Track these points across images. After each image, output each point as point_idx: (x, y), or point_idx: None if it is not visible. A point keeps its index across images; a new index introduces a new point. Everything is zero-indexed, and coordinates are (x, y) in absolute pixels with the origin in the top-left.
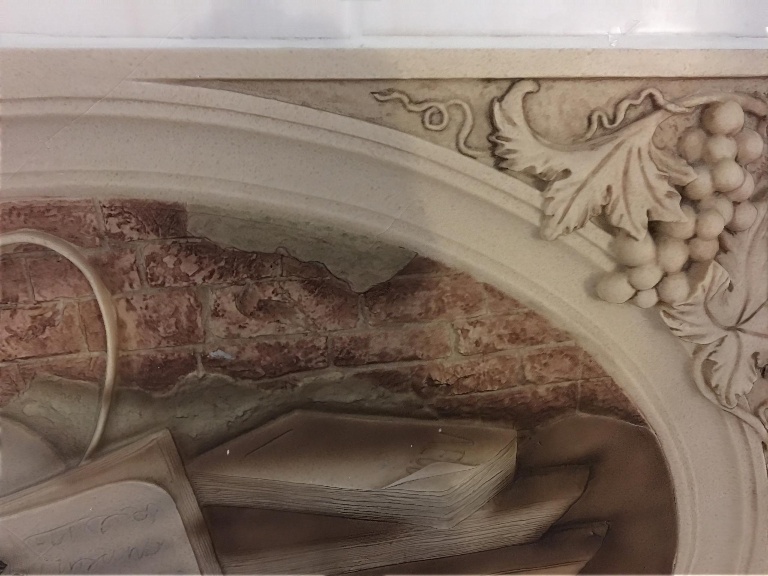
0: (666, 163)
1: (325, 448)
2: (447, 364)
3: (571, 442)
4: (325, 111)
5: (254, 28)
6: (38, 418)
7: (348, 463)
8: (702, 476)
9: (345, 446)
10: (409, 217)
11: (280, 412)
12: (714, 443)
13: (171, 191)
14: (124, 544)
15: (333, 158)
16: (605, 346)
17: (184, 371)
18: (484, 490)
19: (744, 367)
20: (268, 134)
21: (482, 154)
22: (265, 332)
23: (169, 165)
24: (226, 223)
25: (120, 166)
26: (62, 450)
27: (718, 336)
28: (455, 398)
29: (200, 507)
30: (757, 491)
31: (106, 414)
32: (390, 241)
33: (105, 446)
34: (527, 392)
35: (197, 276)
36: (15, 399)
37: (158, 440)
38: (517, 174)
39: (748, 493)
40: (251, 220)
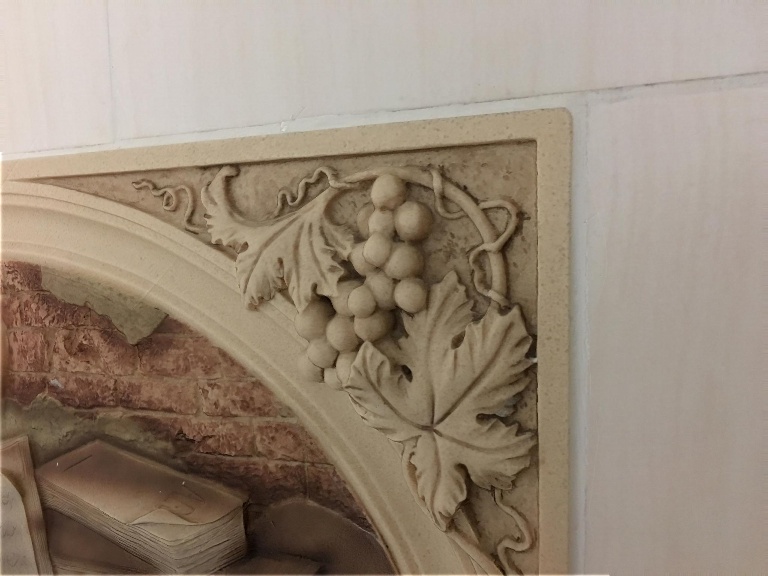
0: (336, 238)
1: (108, 477)
2: (194, 421)
3: (302, 531)
4: (101, 197)
5: (67, 141)
6: None
7: (117, 494)
8: None
9: (119, 479)
10: (163, 283)
11: (89, 439)
12: None
13: (34, 256)
14: None
15: (115, 234)
16: (322, 429)
17: (38, 392)
18: (212, 555)
19: (446, 479)
20: (74, 215)
21: (200, 230)
22: (79, 369)
23: (35, 238)
24: (59, 281)
25: (14, 239)
26: None
27: (409, 434)
28: (203, 456)
29: (43, 507)
30: None
31: None
32: (150, 303)
33: None
34: (260, 464)
35: (46, 320)
36: None
37: (19, 443)
38: (228, 248)
39: None
40: (71, 279)
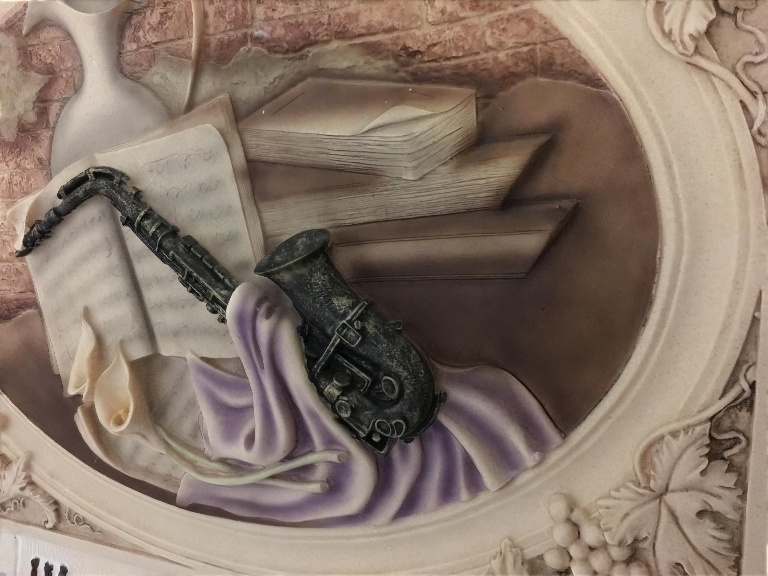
0: None
1: (325, 106)
2: (418, 33)
3: (533, 108)
4: None
5: None
6: (160, 87)
7: (338, 116)
8: (682, 153)
9: (338, 103)
10: None
11: (298, 80)
12: (691, 112)
13: None
14: (197, 179)
15: None
16: (558, 6)
17: (239, 48)
18: (445, 144)
19: (697, 4)
20: None
21: None
22: (288, 13)
23: None
24: None
25: None
26: (172, 112)
27: None
28: (427, 66)
29: (246, 158)
30: (742, 163)
31: (192, 78)
32: None
33: (194, 108)
34: (489, 58)
35: None
36: (149, 72)
37: (221, 99)
38: None
39: (734, 168)
40: None
